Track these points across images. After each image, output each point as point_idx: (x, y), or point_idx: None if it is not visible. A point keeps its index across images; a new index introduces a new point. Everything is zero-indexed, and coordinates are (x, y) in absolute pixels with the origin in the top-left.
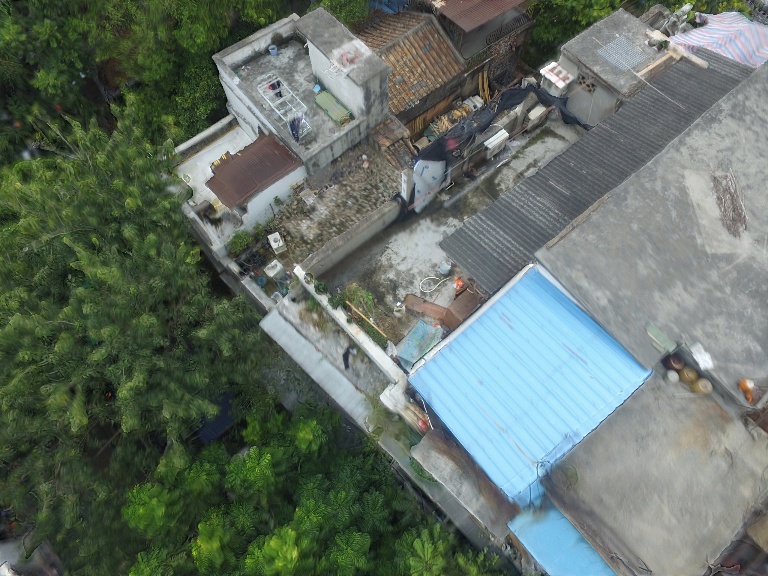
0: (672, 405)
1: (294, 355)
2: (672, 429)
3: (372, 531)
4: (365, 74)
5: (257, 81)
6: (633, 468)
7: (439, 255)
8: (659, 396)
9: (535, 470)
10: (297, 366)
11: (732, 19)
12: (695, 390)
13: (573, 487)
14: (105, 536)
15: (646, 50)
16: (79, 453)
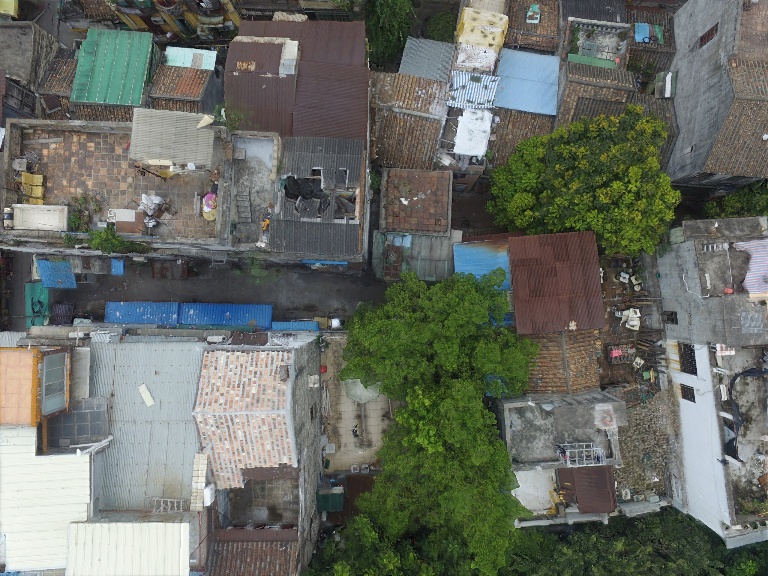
0: None
1: (751, 542)
2: None
3: None
4: (624, 418)
5: (526, 447)
6: None
7: (748, 452)
8: None
9: None
10: None
11: (763, 248)
12: None
13: None
14: None
15: (756, 310)
16: None
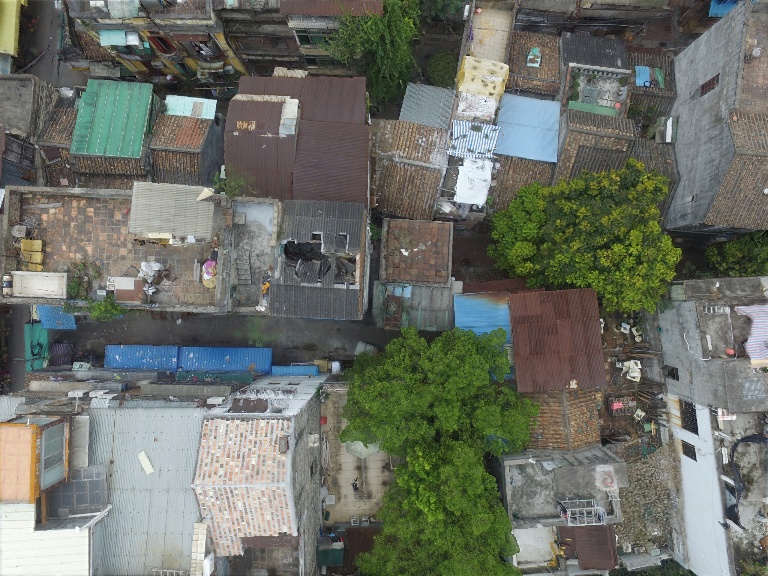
0: None
1: None
2: None
3: None
4: (625, 479)
5: (526, 503)
6: None
7: (750, 514)
8: None
9: None
10: None
11: (764, 314)
12: None
13: None
14: None
15: (758, 376)
16: None
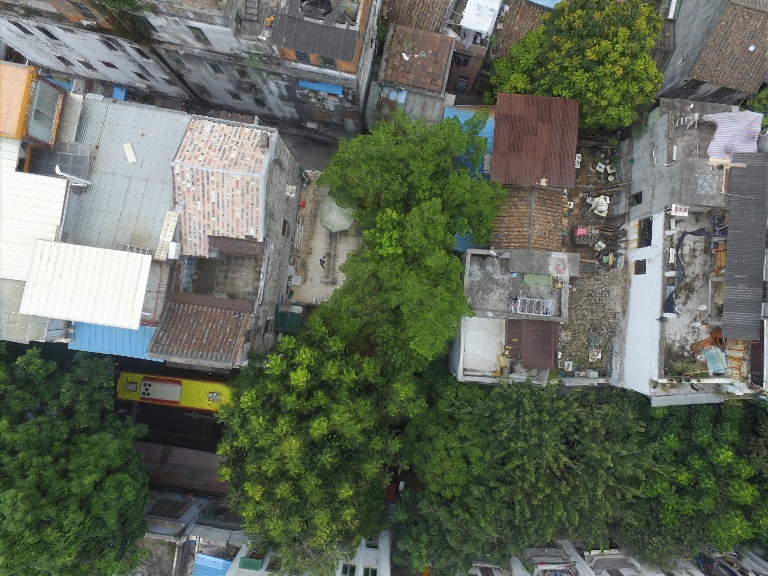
0: None
1: (675, 404)
2: None
3: (714, 417)
4: (576, 268)
5: (481, 298)
6: None
7: (686, 320)
8: None
9: None
10: (626, 393)
11: (729, 119)
12: None
13: None
14: (631, 510)
15: (714, 174)
16: None
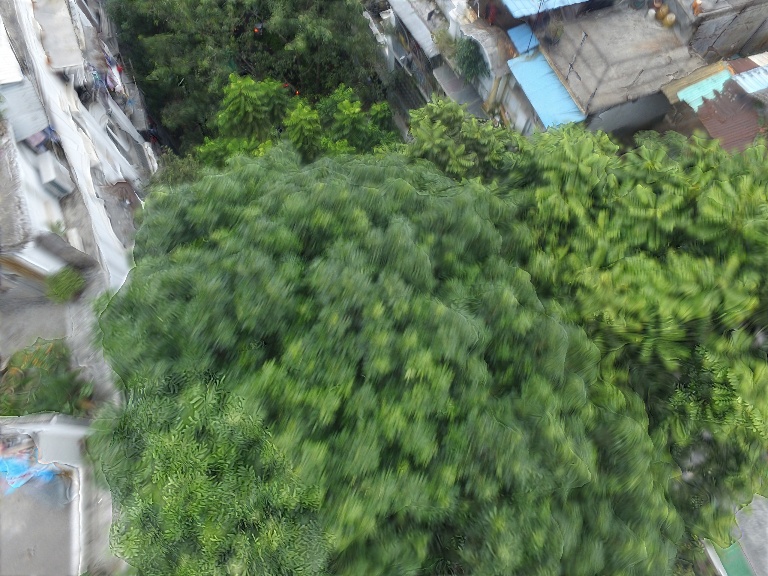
0: (644, 30)
1: (395, 7)
2: (638, 40)
3: None
4: None
5: None
6: (602, 50)
7: None
8: (637, 24)
9: (538, 8)
10: None
11: None
12: (663, 24)
13: (558, 48)
14: None
15: None
16: (227, 57)
